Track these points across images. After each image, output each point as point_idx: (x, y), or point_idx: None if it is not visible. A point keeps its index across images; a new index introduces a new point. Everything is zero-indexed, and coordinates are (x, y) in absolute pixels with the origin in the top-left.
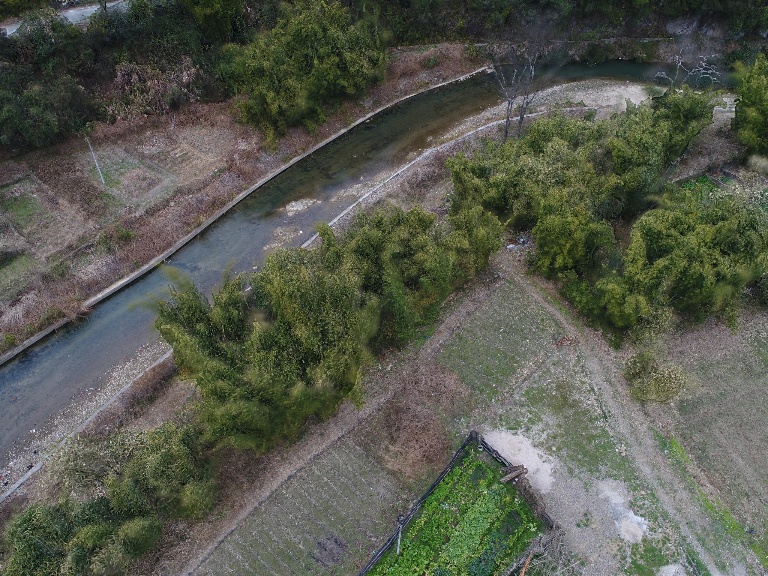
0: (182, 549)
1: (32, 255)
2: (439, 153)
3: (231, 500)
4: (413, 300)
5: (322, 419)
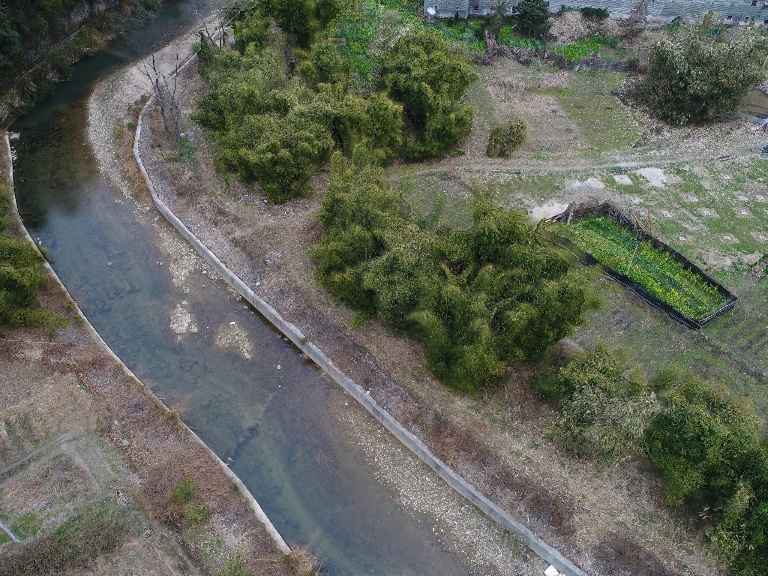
0: None
1: None
2: (182, 186)
3: None
4: None
5: None
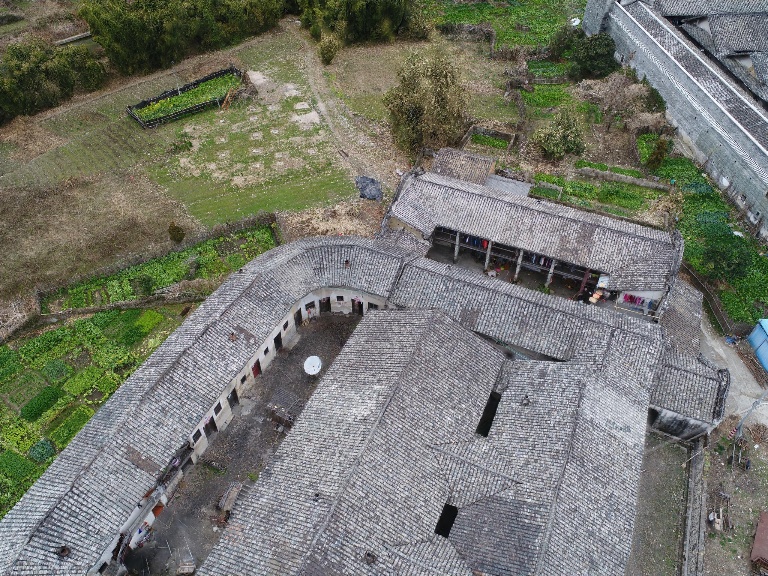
0: (85, 97)
1: (28, 20)
2: None
3: (111, 87)
4: (222, 26)
5: (164, 68)
